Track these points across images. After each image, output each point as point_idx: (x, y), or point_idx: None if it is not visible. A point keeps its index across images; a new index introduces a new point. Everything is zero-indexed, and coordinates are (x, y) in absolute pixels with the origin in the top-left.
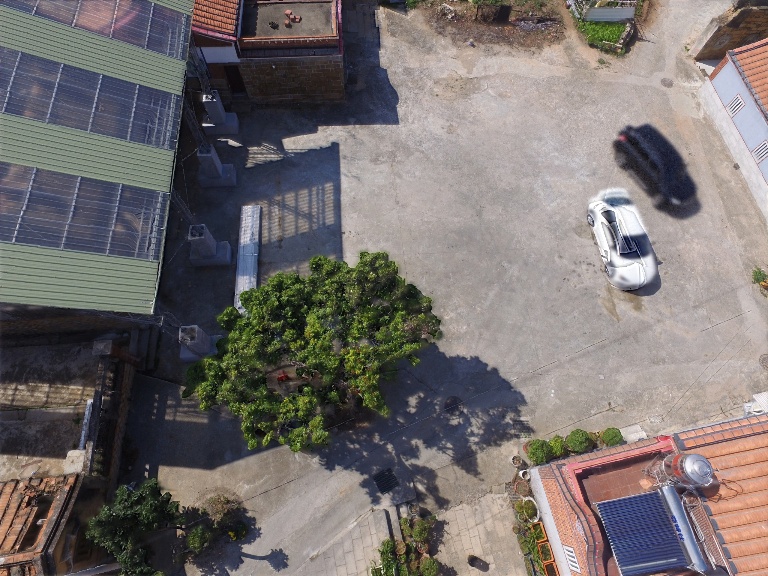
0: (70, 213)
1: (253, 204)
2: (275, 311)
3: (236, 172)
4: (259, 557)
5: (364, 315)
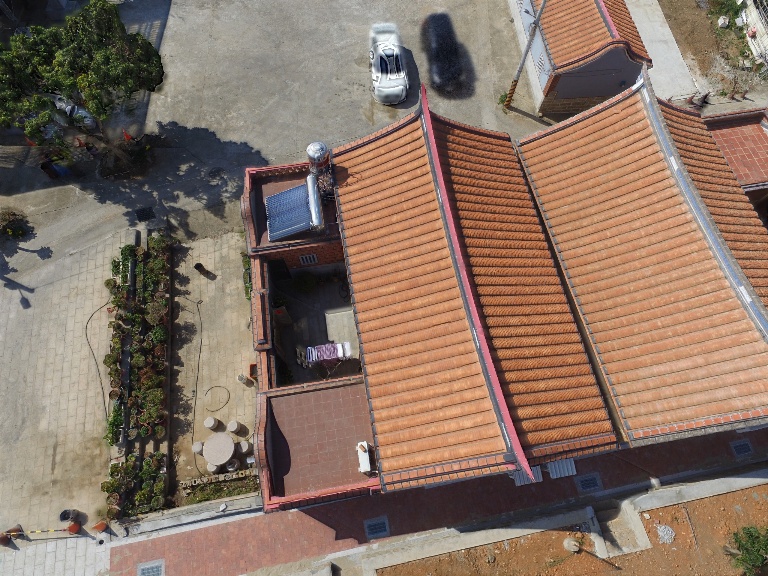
0: None
1: None
2: (30, 45)
3: (82, 10)
4: (31, 250)
5: (98, 52)
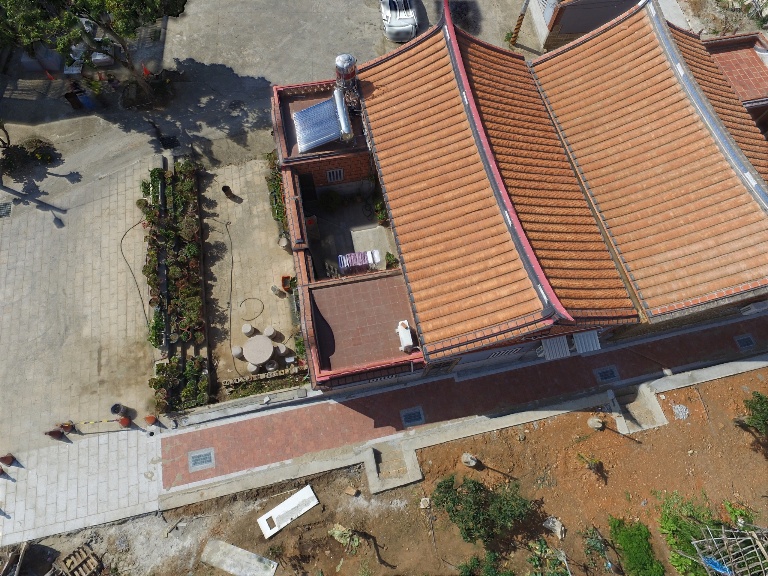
0: None
1: None
2: None
3: None
4: (60, 175)
5: None
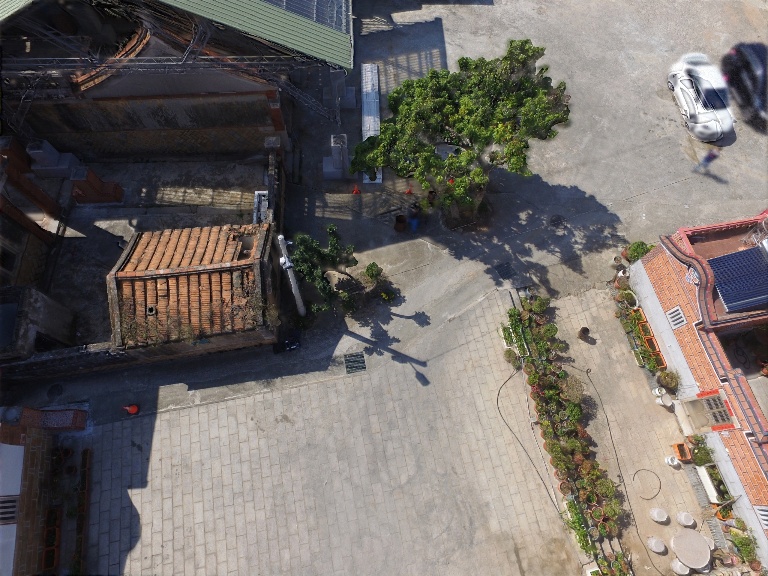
0: None
1: (370, 63)
2: (436, 91)
3: None
4: (406, 316)
5: (509, 98)
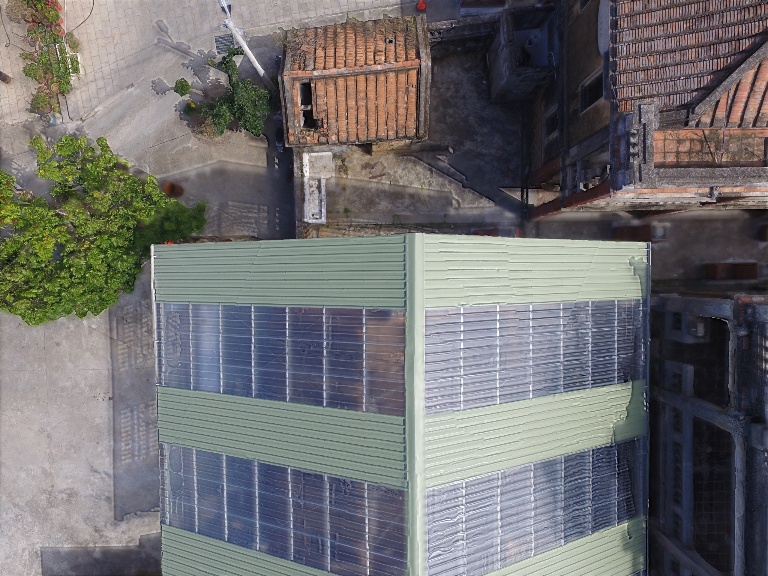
0: (221, 347)
1: None
2: None
3: None
4: None
5: None
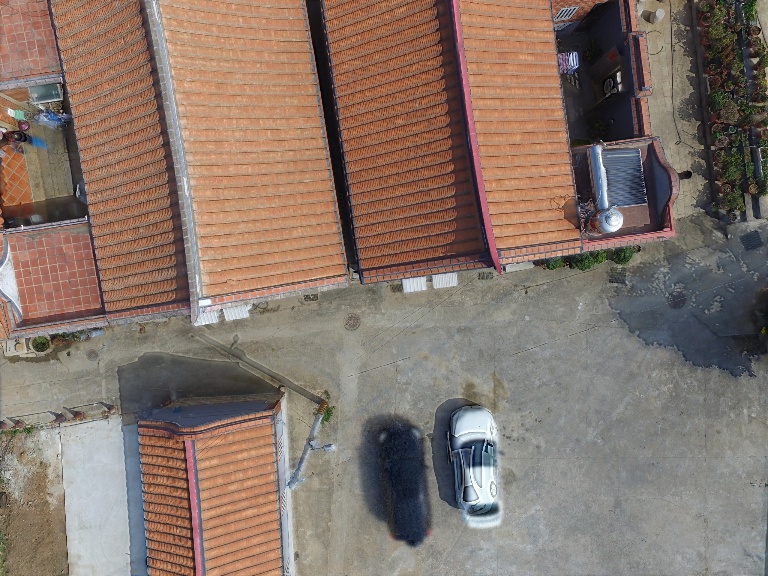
0: None
1: None
2: None
3: None
4: None
5: None
